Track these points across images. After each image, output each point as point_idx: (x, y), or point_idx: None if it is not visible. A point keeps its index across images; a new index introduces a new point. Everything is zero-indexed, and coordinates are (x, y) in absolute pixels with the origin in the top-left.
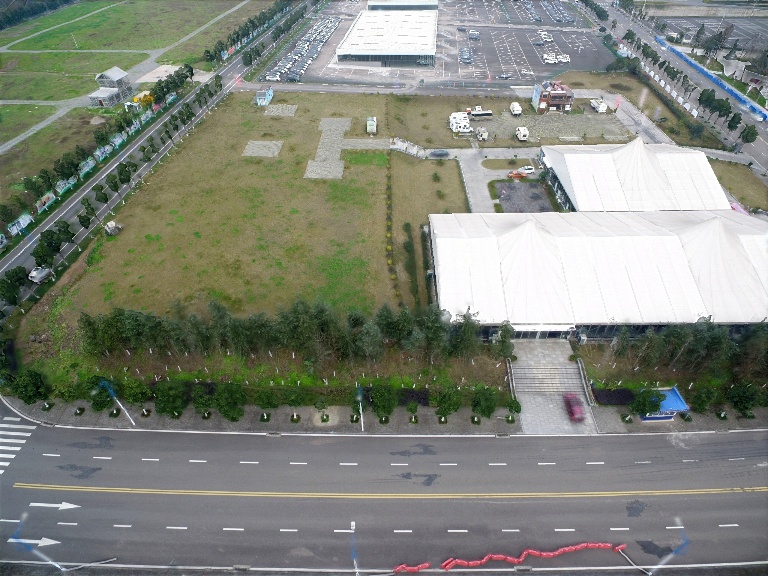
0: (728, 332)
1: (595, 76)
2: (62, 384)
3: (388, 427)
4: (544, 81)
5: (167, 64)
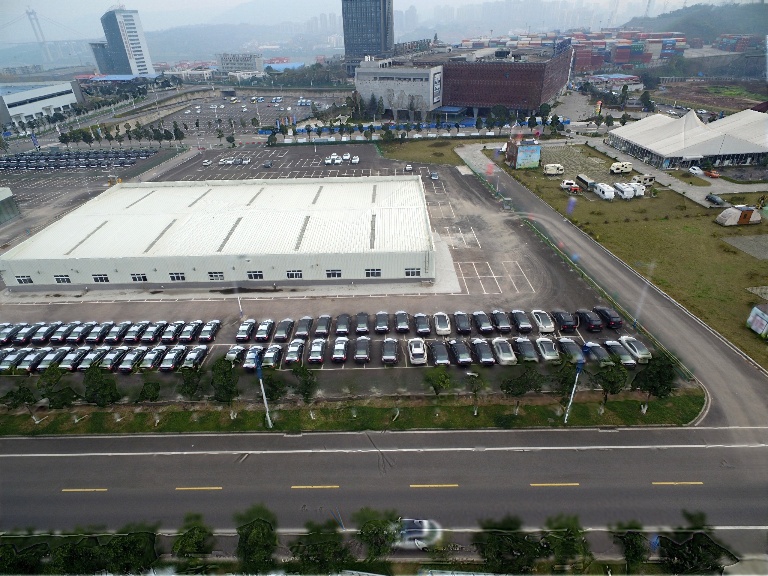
0: None
1: (399, 151)
2: None
3: None
4: None
5: None
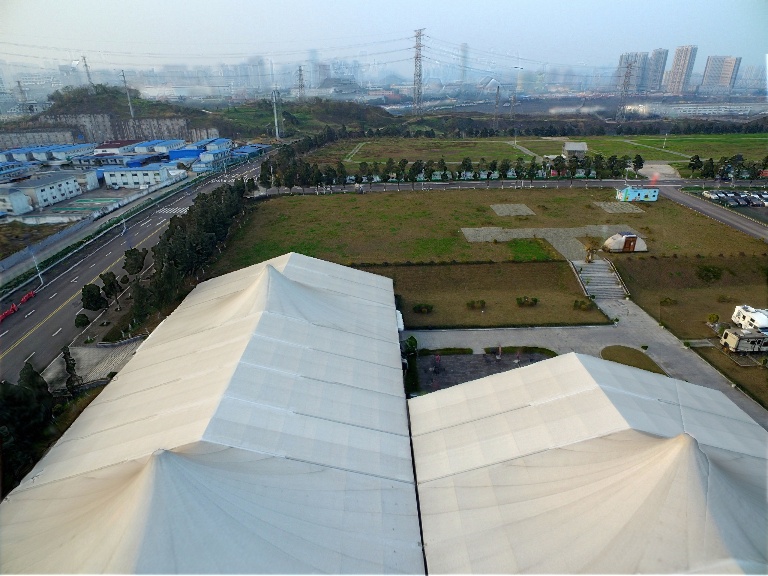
0: None
1: None
2: (209, 194)
3: None
4: None
5: (671, 165)
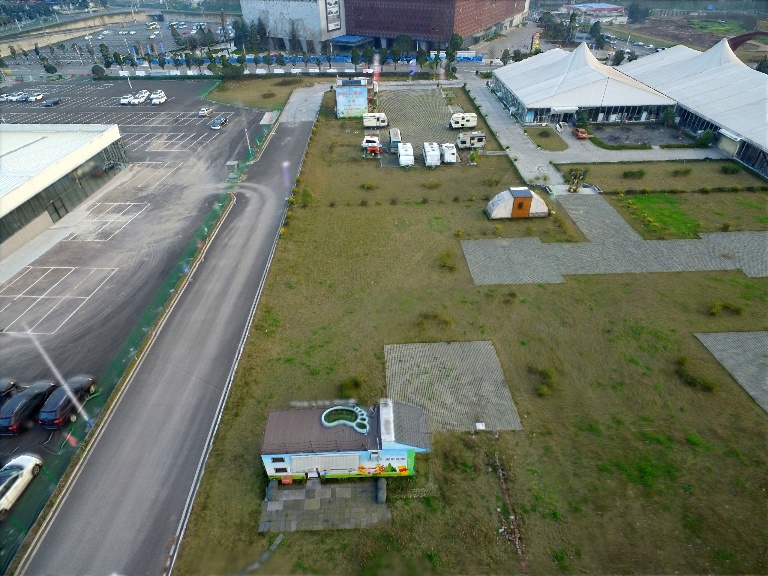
0: None
1: (233, 90)
2: None
3: None
4: (337, 80)
5: None
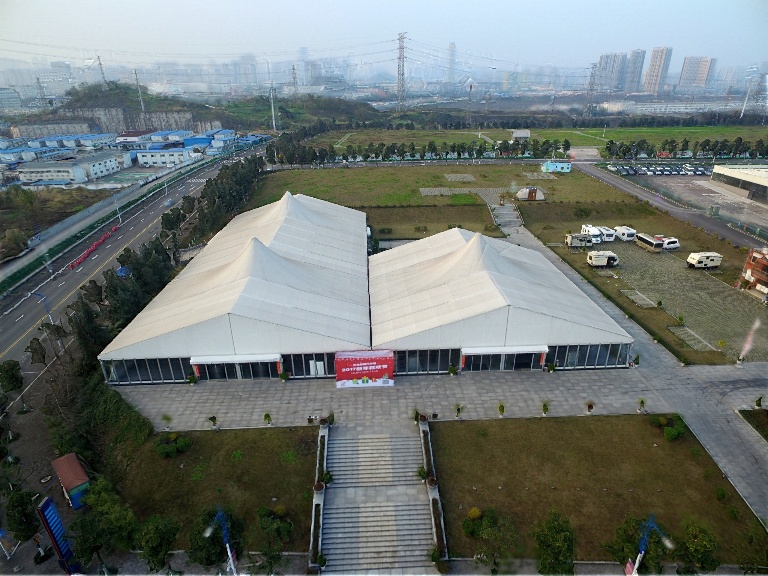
0: (132, 254)
1: None
2: None
3: (186, 224)
4: None
5: None
